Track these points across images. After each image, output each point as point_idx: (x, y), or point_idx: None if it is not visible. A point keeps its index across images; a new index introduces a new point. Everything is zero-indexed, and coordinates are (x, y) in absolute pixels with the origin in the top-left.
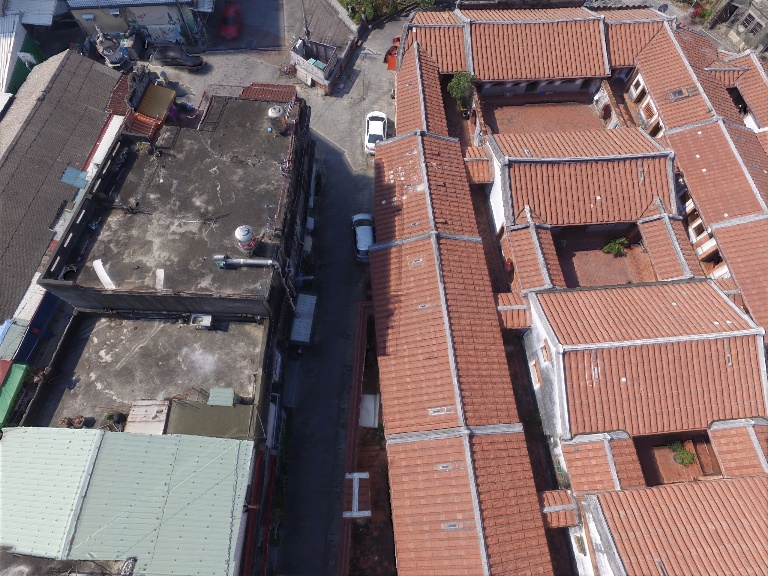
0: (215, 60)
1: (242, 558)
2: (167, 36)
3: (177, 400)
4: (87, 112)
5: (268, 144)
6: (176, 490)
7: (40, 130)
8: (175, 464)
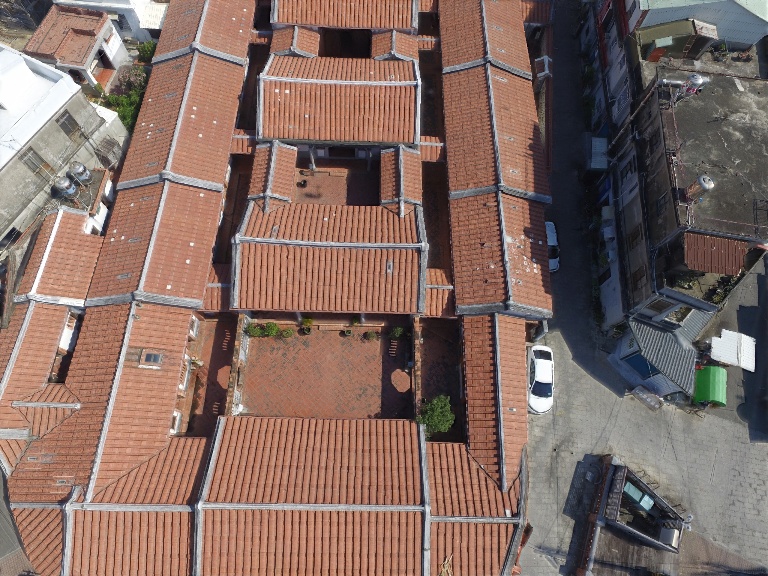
0: None
1: None
2: None
3: (692, 34)
4: None
5: None
6: None
7: None
8: None
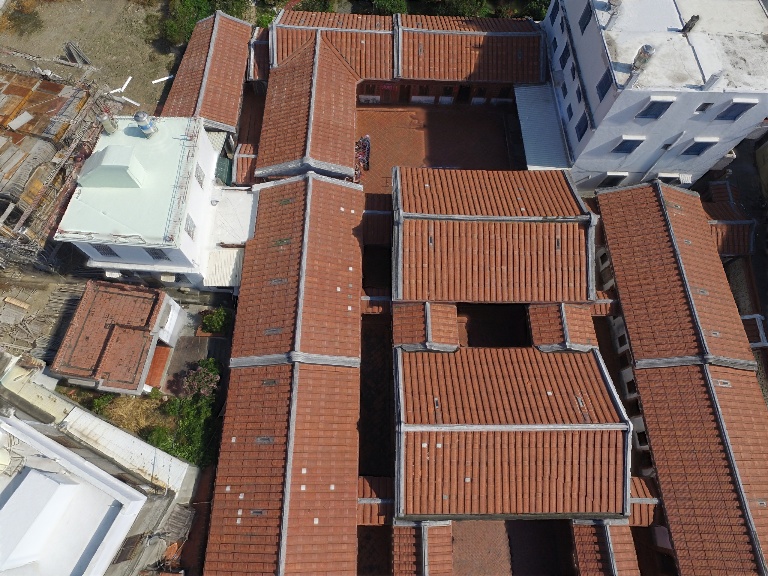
0: None
1: None
2: None
3: None
4: None
5: None
6: None
7: None
8: None
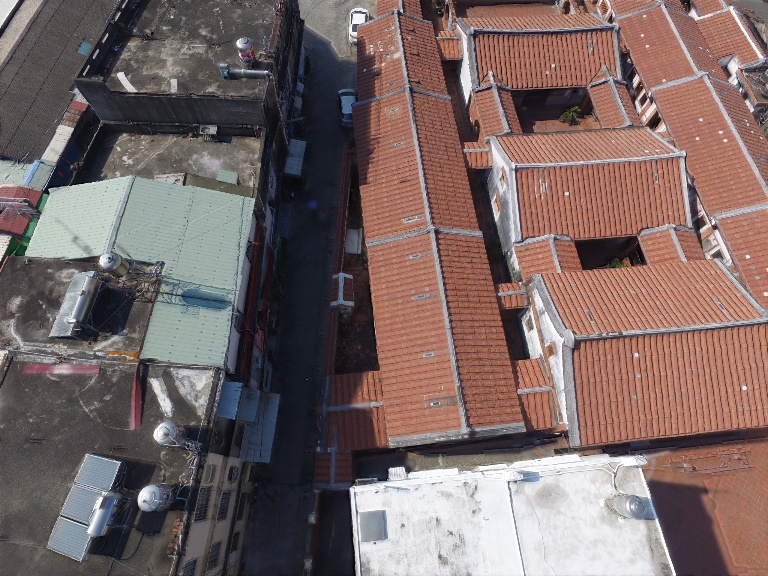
0: None
1: (247, 294)
2: None
3: (191, 173)
4: None
5: None
6: (194, 223)
7: (58, 8)
8: (192, 205)
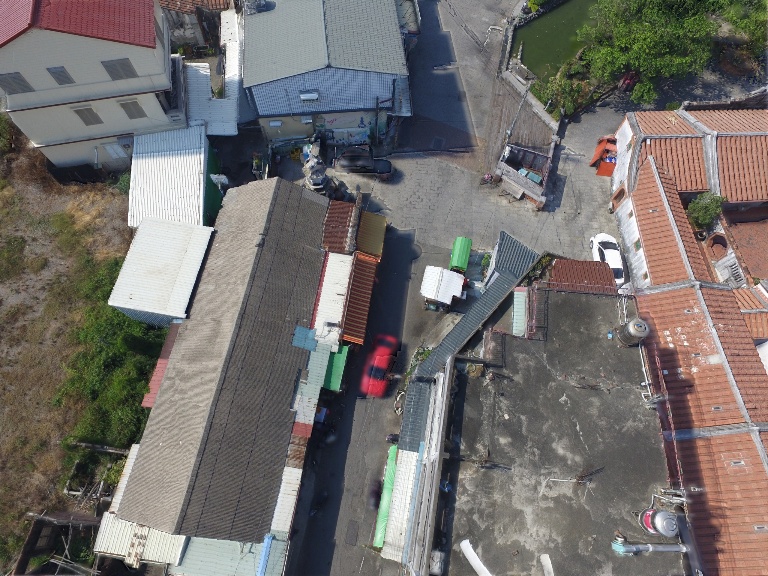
0: (404, 165)
1: None
2: (352, 138)
3: None
4: (305, 253)
5: (615, 358)
6: None
7: (265, 284)
8: None
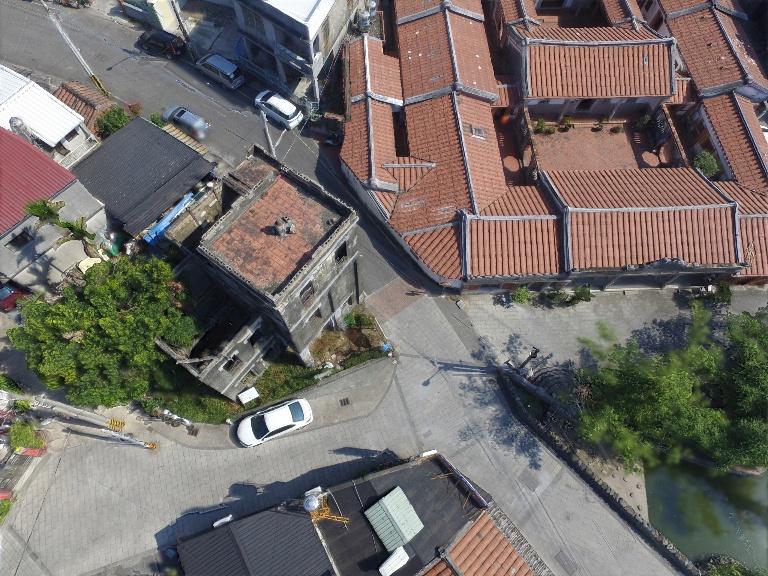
0: None
1: None
2: None
3: None
4: None
5: None
6: None
7: None
8: None
